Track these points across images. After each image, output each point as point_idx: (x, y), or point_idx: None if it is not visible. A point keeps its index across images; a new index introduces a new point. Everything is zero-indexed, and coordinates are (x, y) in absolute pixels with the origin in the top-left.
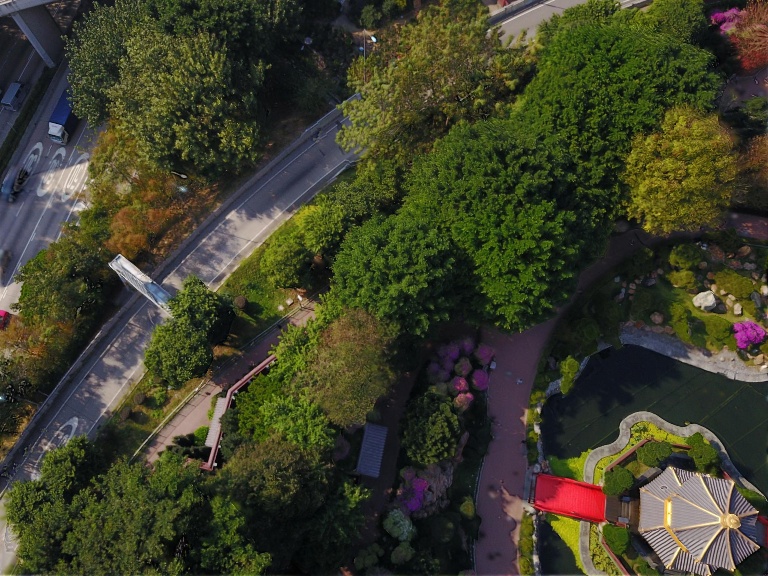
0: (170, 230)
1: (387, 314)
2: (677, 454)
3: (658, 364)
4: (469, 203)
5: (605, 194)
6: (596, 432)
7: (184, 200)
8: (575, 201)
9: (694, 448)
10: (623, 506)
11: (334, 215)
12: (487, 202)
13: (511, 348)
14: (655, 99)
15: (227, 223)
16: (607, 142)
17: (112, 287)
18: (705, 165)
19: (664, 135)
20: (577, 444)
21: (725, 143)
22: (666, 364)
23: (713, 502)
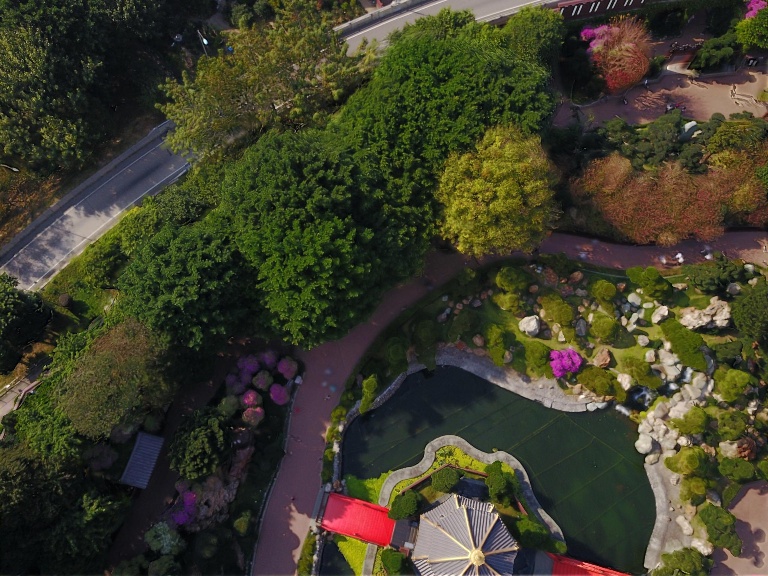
0: (8, 223)
1: (158, 325)
2: (476, 481)
3: (476, 387)
4: (259, 215)
5: (418, 212)
6: (401, 453)
7: (28, 193)
8: (382, 218)
9: (490, 476)
10: (412, 531)
11: (148, 218)
12: (275, 215)
13: (324, 363)
14: (475, 117)
15: (64, 219)
16: (418, 159)
17: None
18: (512, 188)
19: (478, 155)
20: (379, 464)
21: (536, 167)
22: (484, 388)
23: (469, 536)
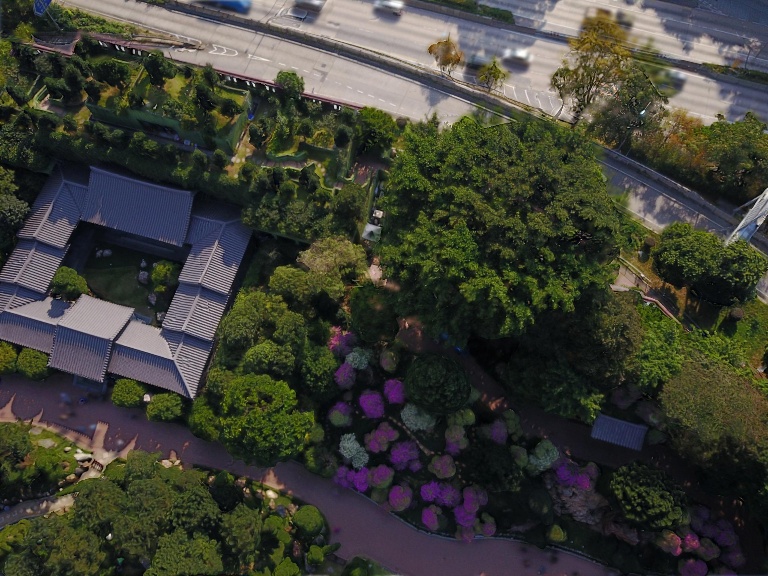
0: None
1: None
2: None
3: None
4: None
5: None
6: None
7: None
8: None
9: None
10: None
11: None
12: None
13: None
14: None
15: None
16: None
17: (736, 196)
18: None
19: None
20: None
21: None
22: None
23: None
